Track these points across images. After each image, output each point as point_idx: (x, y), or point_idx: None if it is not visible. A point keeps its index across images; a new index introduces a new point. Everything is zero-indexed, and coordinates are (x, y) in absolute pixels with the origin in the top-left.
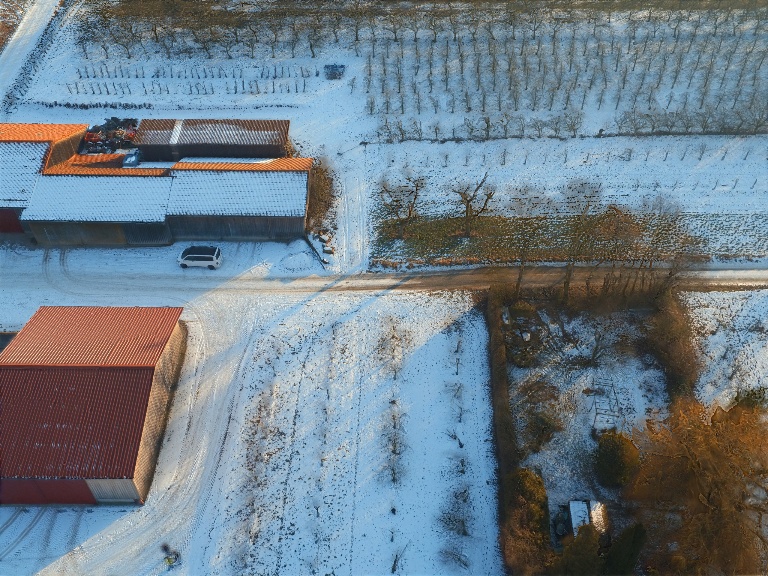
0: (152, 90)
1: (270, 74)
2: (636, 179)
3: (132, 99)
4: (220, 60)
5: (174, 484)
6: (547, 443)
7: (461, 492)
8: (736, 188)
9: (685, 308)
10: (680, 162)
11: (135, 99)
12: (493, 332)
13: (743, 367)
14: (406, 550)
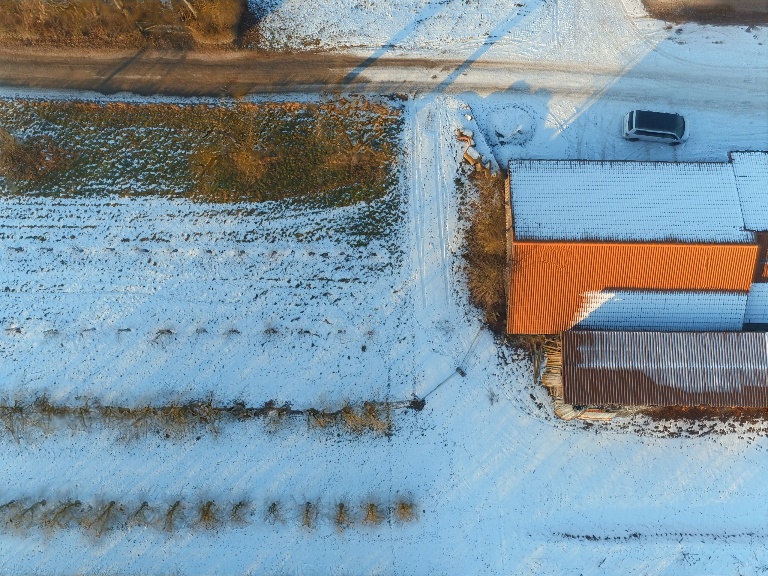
0: None
1: None
2: None
3: None
4: None
5: None
6: None
7: None
8: None
9: None
10: None
11: None
12: None
13: None
14: None
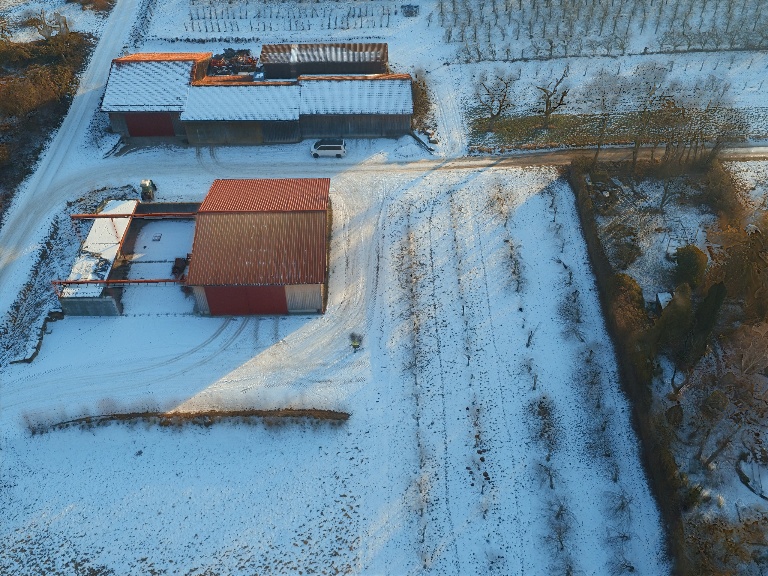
0: (256, 28)
1: (355, 14)
2: (679, 84)
3: (241, 35)
4: (309, 3)
5: (345, 300)
6: (632, 263)
7: (573, 292)
8: (761, 89)
9: (729, 173)
10: (713, 71)
11: (244, 35)
12: (580, 190)
13: None
14: (538, 328)
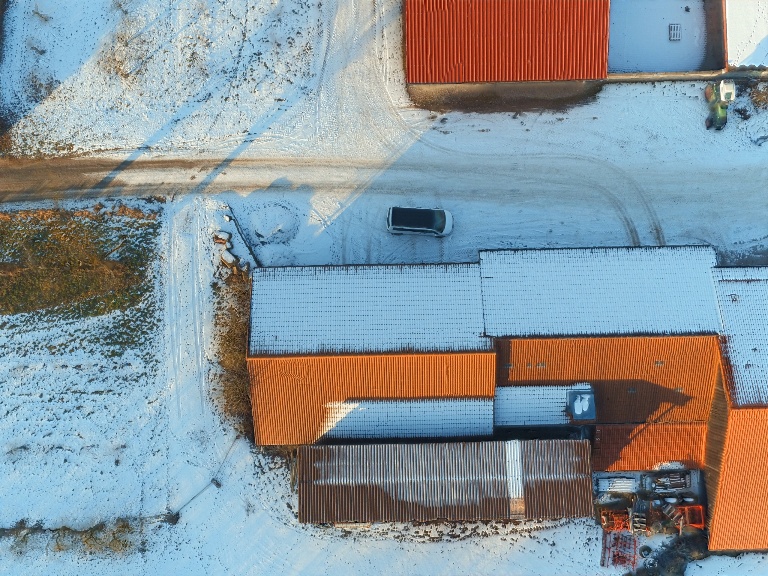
0: None
1: None
2: None
3: None
4: None
5: None
6: None
7: None
8: None
9: None
10: None
11: None
12: None
13: None
14: None
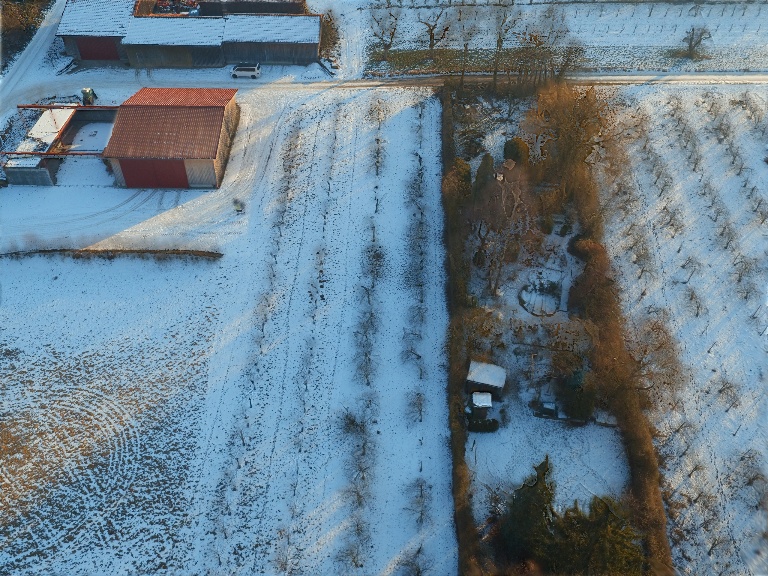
0: None
1: None
2: None
3: None
4: None
5: (237, 179)
6: (475, 157)
7: None
8: (623, 32)
9: None
10: (586, 18)
11: None
12: (444, 102)
13: (608, 122)
14: (383, 197)
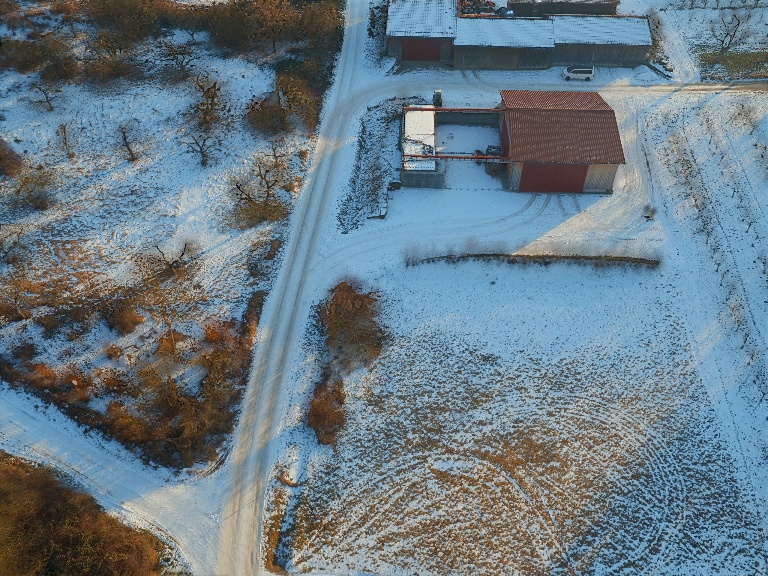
0: None
1: None
2: None
3: None
4: None
5: (627, 184)
6: None
7: None
8: None
9: None
10: None
11: None
12: None
13: None
14: None
